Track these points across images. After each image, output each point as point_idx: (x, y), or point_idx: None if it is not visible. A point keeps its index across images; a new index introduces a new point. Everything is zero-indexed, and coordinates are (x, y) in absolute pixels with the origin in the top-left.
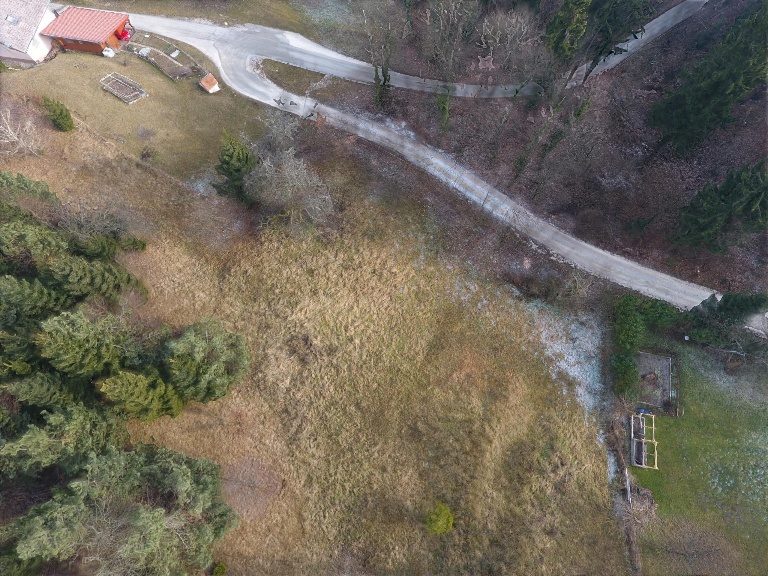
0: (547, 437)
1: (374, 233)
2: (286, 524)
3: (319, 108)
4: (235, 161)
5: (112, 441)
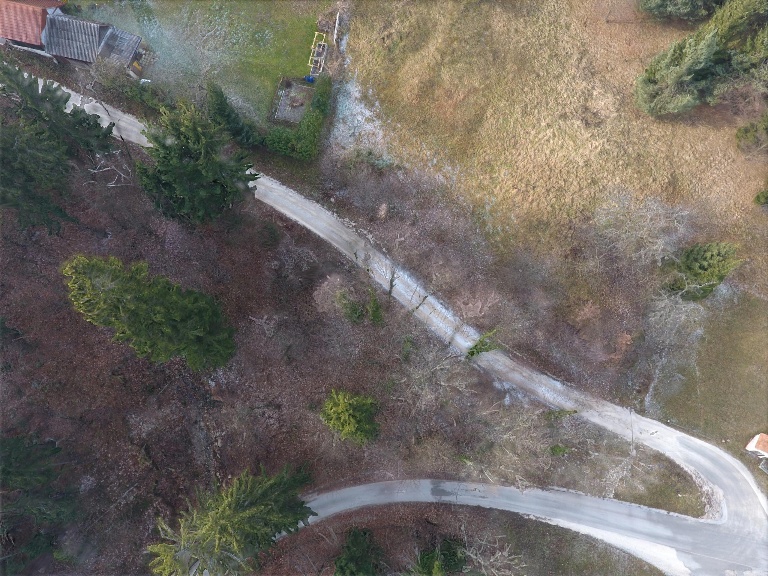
0: (392, 56)
1: (538, 227)
2: (580, 1)
3: (614, 425)
4: (712, 247)
5: (726, 4)
